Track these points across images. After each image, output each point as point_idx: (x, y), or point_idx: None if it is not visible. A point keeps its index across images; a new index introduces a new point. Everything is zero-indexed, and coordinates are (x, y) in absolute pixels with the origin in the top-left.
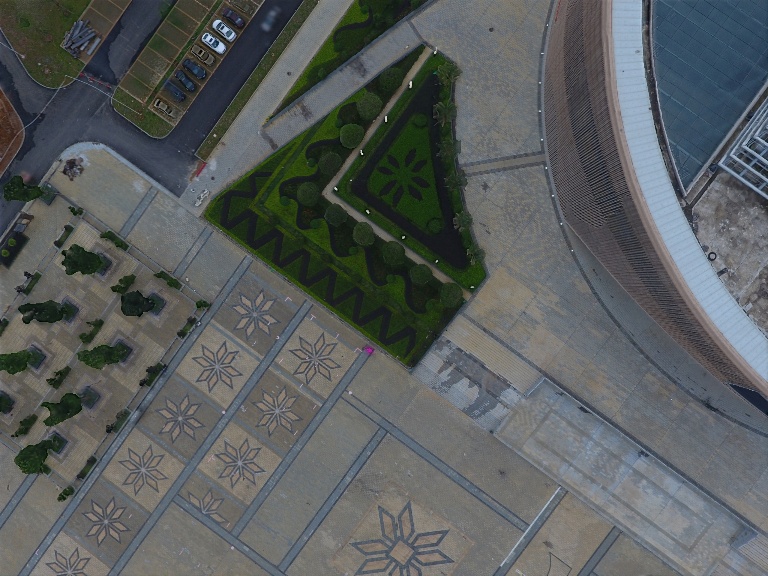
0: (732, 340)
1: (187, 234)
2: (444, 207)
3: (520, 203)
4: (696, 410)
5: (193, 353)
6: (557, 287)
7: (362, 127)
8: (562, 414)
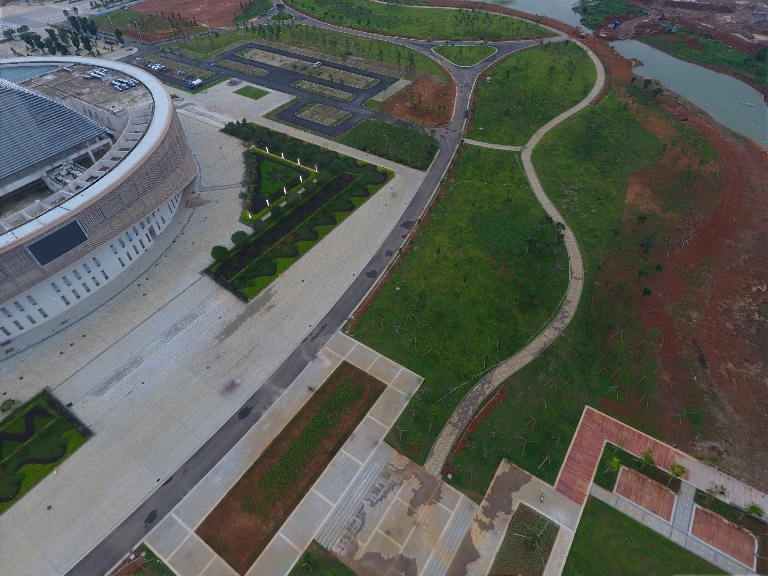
0: None
1: None
2: None
3: None
4: None
5: None
6: None
7: None
8: None
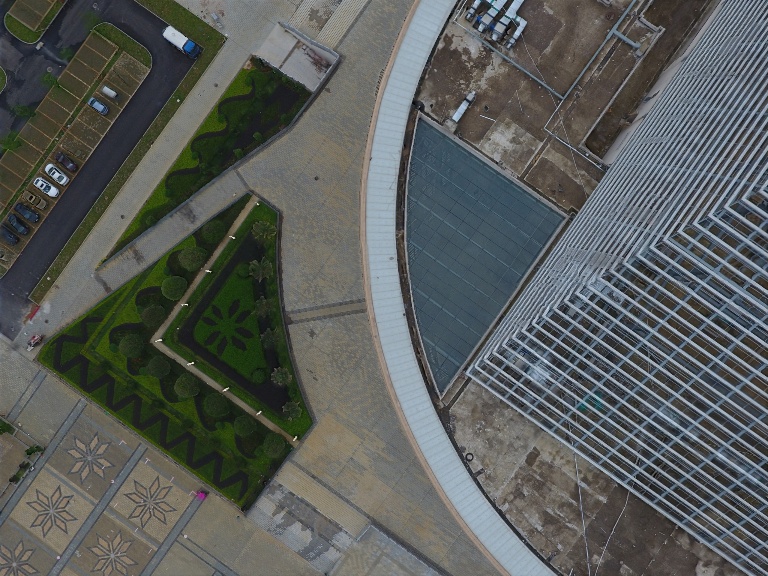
0: (486, 543)
1: (21, 378)
2: (269, 357)
3: (346, 350)
4: None
5: (27, 498)
6: (383, 433)
7: (185, 279)
8: (393, 557)
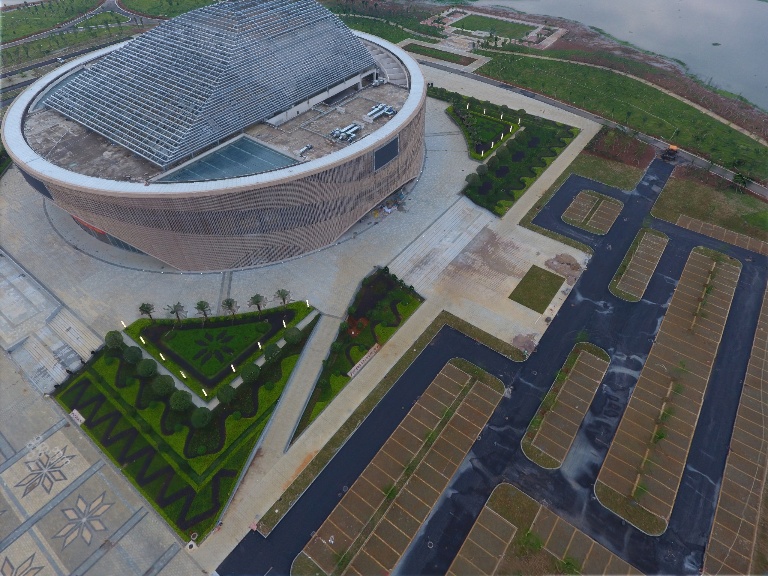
0: (9, 142)
1: None
2: None
3: None
4: (66, 249)
5: None
6: None
7: None
8: None
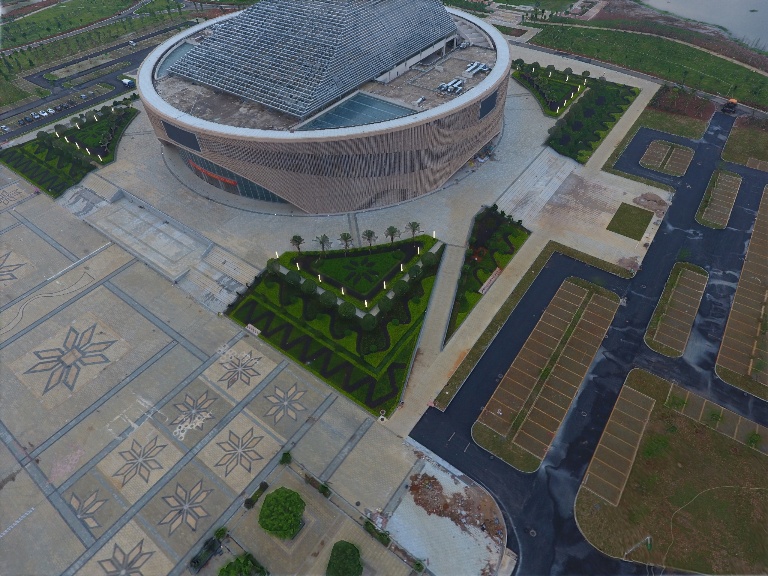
0: None
1: None
2: None
3: None
4: (200, 200)
5: None
6: None
7: None
8: (128, 209)
